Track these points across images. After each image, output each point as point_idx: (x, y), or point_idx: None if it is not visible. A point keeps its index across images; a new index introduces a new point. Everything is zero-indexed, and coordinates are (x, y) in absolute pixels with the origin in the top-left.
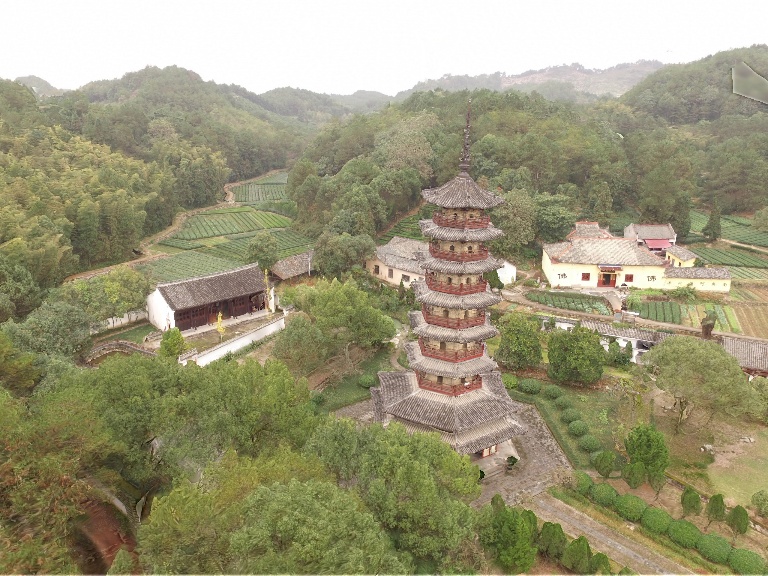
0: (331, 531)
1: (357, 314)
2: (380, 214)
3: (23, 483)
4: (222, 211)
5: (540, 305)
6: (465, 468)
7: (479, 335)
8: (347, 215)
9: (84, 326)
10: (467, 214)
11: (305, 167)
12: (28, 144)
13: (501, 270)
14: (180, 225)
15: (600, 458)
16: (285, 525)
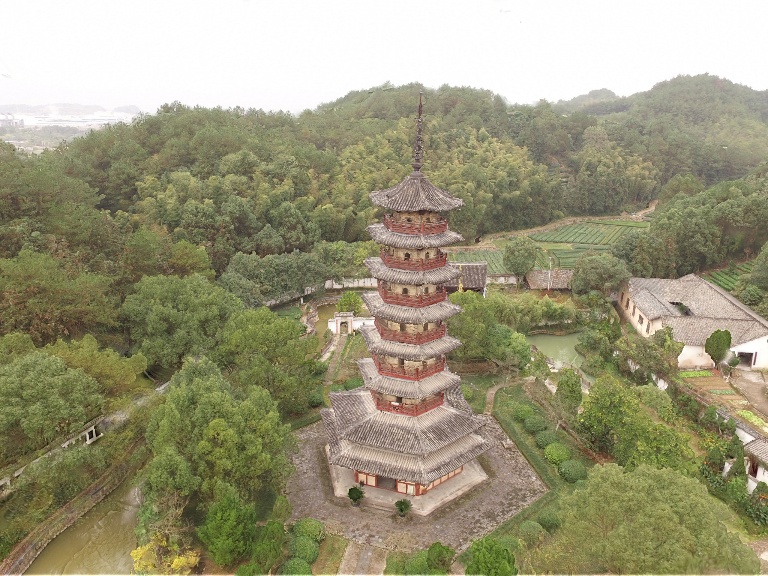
0: (16, 389)
1: (457, 321)
2: (697, 245)
3: (14, 307)
4: (614, 222)
5: (764, 404)
6: (219, 438)
7: (402, 353)
8: (632, 236)
9: (320, 275)
10: (403, 216)
11: (681, 183)
12: (440, 141)
13: (763, 344)
14: (551, 227)
15: (431, 546)
16: (5, 371)
